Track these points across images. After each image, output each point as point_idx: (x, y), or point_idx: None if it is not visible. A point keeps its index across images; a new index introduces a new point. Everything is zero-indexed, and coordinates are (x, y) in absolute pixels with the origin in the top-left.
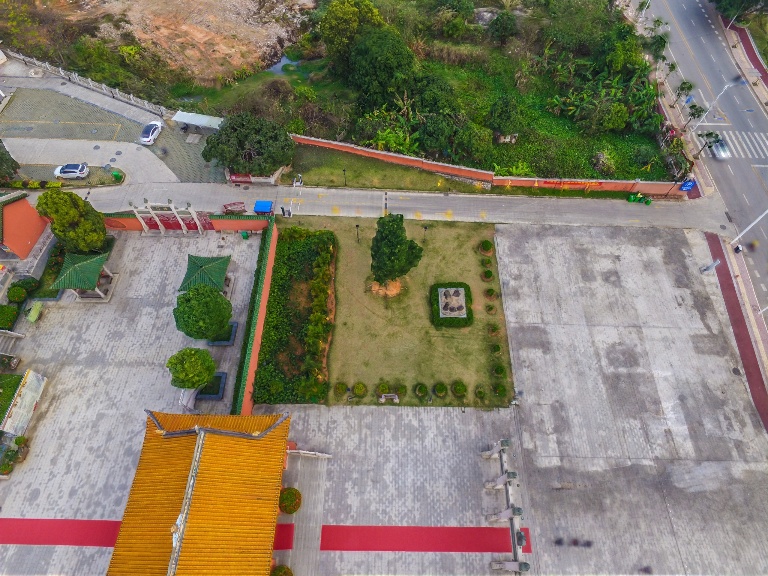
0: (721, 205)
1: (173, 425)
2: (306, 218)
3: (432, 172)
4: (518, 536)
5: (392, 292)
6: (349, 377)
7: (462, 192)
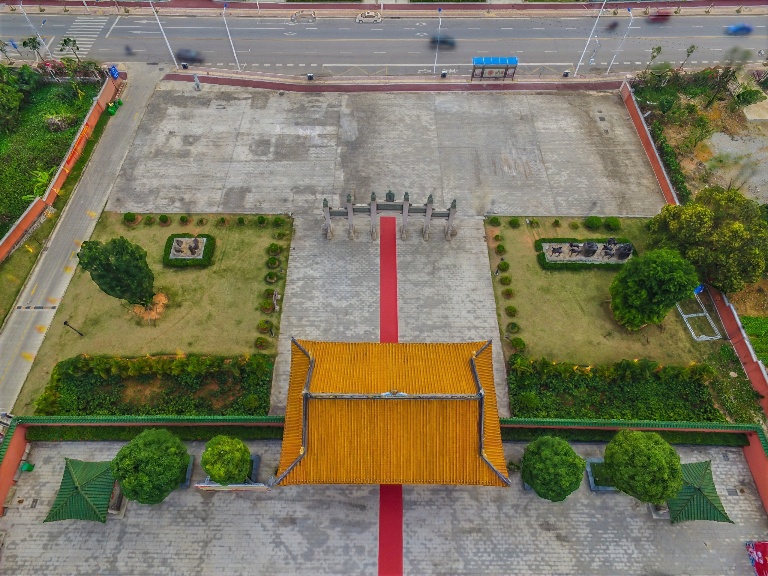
0: (139, 65)
1: (293, 451)
2: (23, 397)
3: (7, 258)
4: (388, 199)
5: (162, 300)
6: (250, 337)
7: (49, 234)
